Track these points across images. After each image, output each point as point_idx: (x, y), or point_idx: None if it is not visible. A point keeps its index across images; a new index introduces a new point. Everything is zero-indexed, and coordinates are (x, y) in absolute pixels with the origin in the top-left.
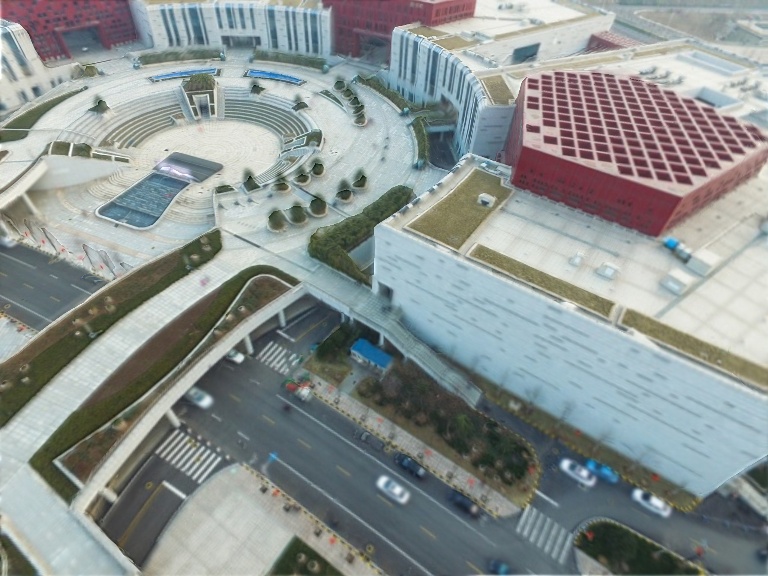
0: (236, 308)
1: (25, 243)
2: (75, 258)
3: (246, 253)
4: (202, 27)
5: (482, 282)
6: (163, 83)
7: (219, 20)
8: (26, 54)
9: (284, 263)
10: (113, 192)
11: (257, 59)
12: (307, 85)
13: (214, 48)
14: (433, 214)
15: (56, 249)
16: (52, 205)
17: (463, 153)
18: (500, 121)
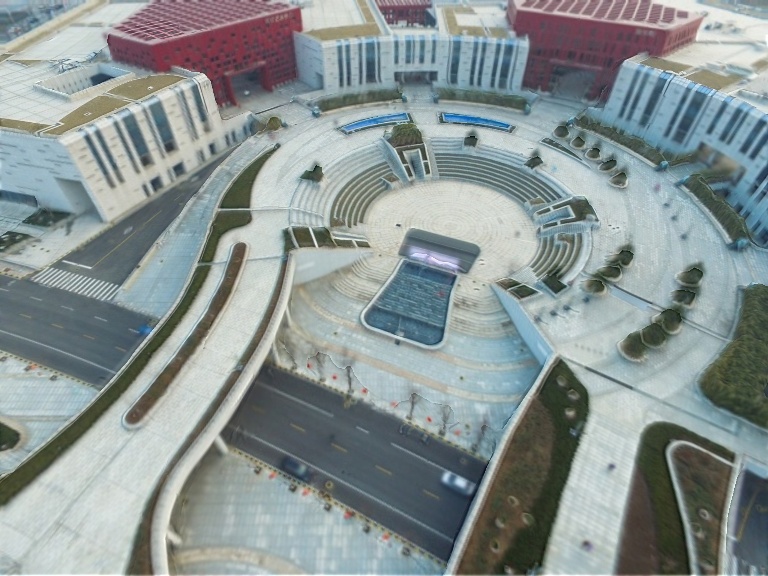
0: (695, 513)
1: (301, 374)
2: (374, 398)
3: (622, 400)
4: (376, 63)
5: None
6: (358, 135)
7: (396, 55)
8: (208, 107)
9: (684, 417)
10: (368, 290)
11: (443, 99)
12: (518, 131)
13: (389, 86)
14: None
15: (351, 387)
16: (303, 311)
17: (761, 221)
18: None
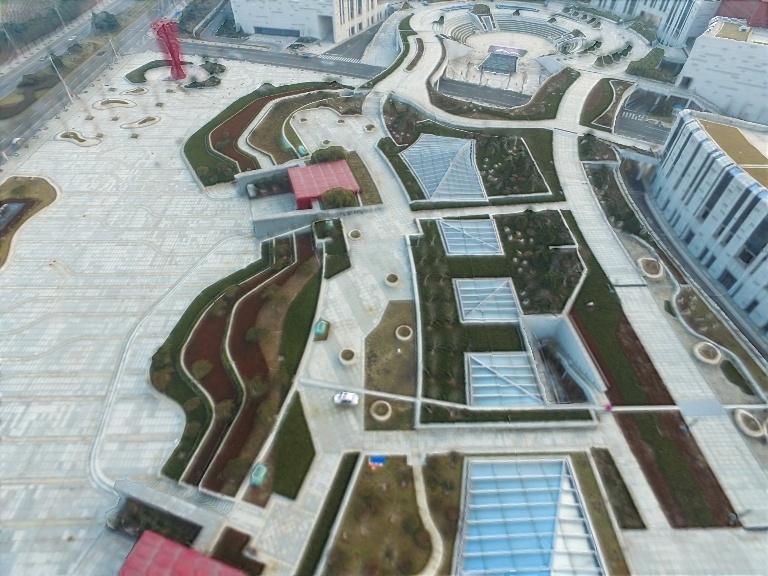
0: None
1: (457, 80)
2: (490, 85)
3: None
4: None
5: (764, 53)
6: (454, 12)
7: None
8: None
9: None
10: (477, 62)
11: None
12: (542, 12)
13: None
14: (722, 34)
15: (481, 80)
16: None
17: (668, 42)
18: (709, 11)
